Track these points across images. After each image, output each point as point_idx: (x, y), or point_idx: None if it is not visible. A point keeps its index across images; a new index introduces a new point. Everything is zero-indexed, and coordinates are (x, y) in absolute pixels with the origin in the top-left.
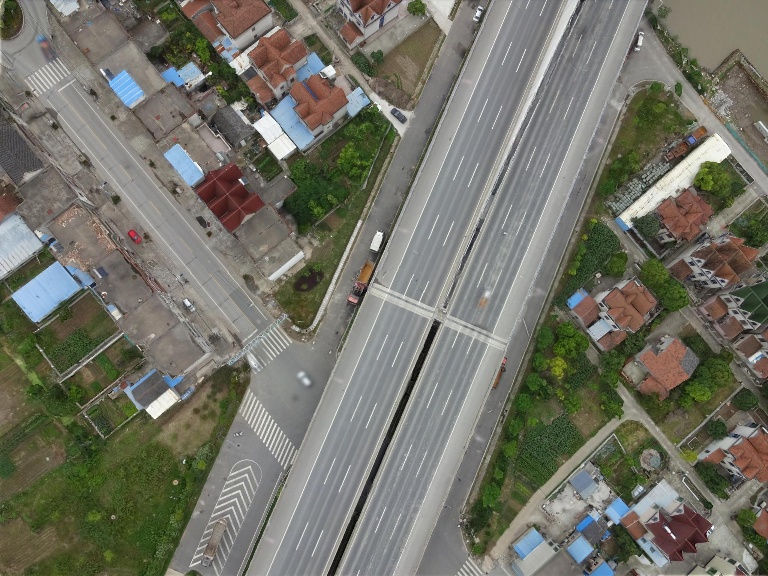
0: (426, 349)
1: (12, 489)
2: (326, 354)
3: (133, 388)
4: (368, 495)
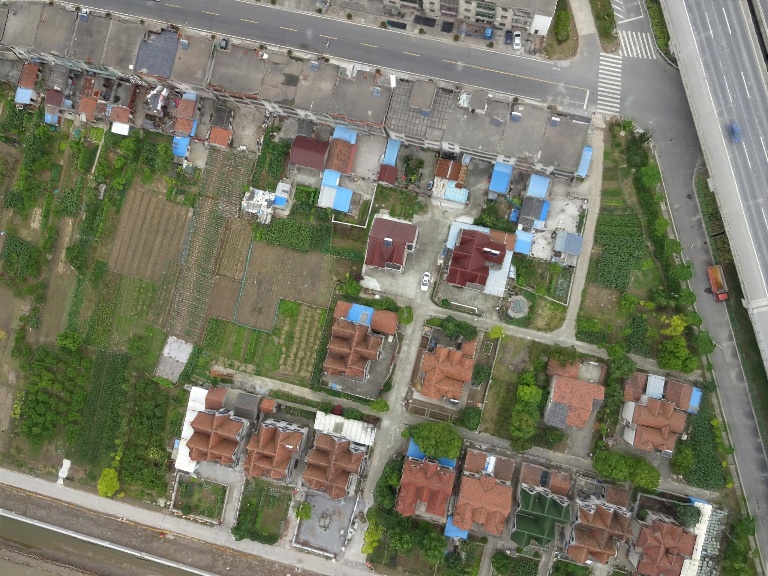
0: None
1: None
2: None
3: None
4: None
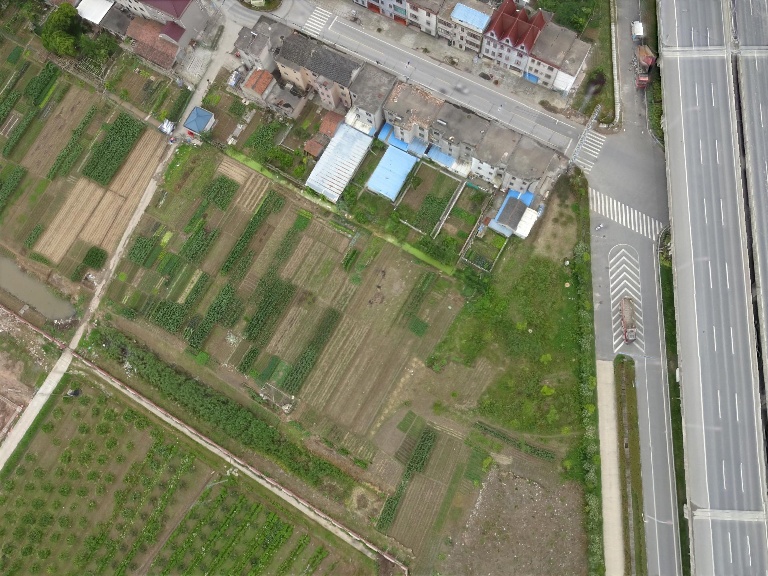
0: (735, 80)
1: (432, 343)
2: (640, 135)
3: (497, 219)
4: (750, 217)
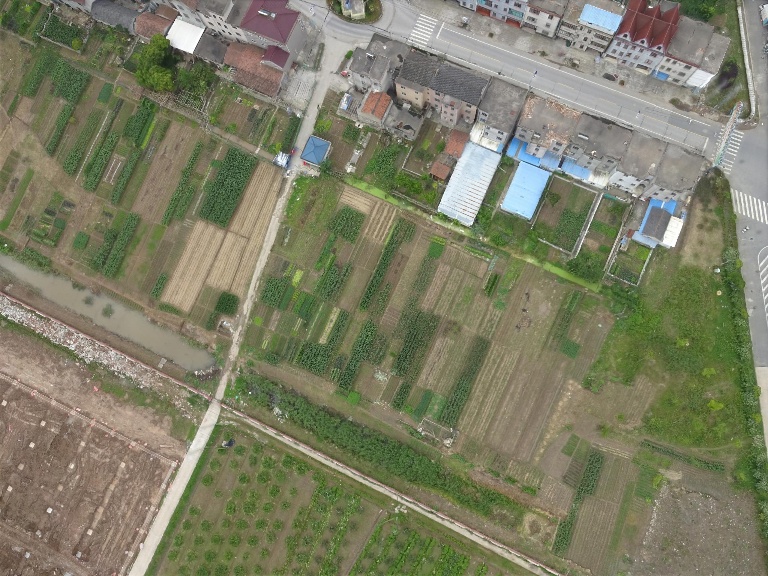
0: None
1: (586, 363)
2: None
3: (641, 230)
4: None
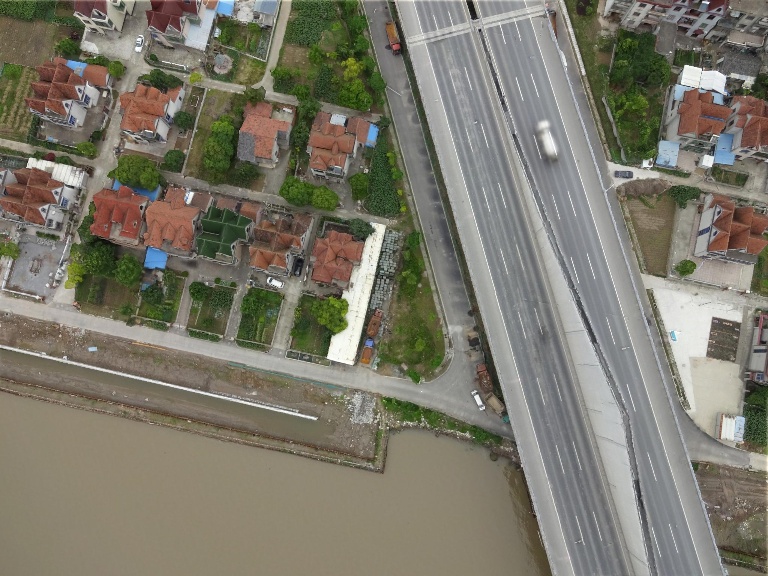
0: None
1: None
2: None
3: None
4: None
